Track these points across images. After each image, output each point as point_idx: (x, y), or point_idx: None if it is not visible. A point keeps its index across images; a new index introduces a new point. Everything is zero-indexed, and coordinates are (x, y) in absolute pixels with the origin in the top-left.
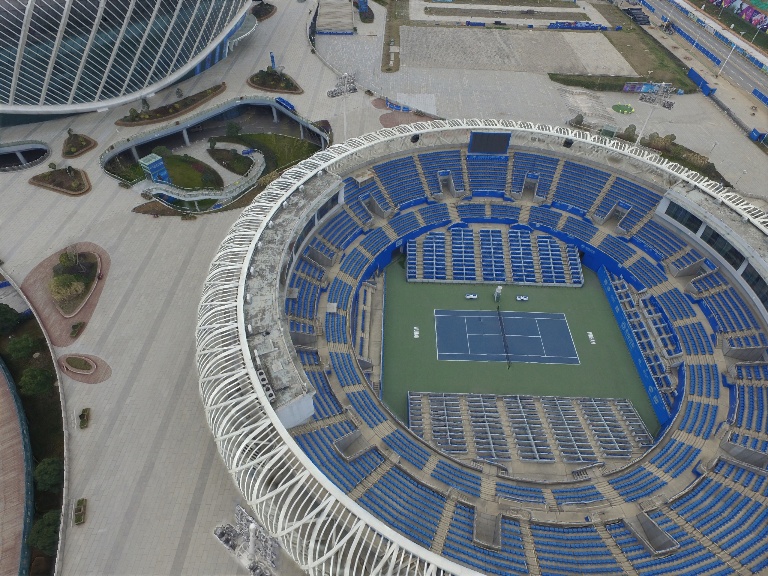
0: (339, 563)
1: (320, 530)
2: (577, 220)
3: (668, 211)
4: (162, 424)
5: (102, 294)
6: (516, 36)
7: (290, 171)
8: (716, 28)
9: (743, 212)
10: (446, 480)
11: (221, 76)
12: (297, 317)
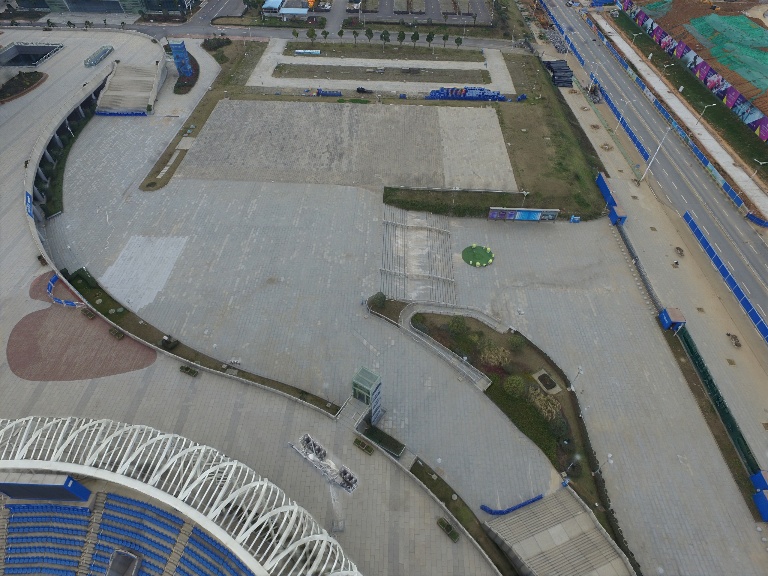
0: None
1: None
2: None
3: None
4: None
5: None
6: (371, 116)
7: None
8: (660, 90)
9: None
10: None
11: None
12: None
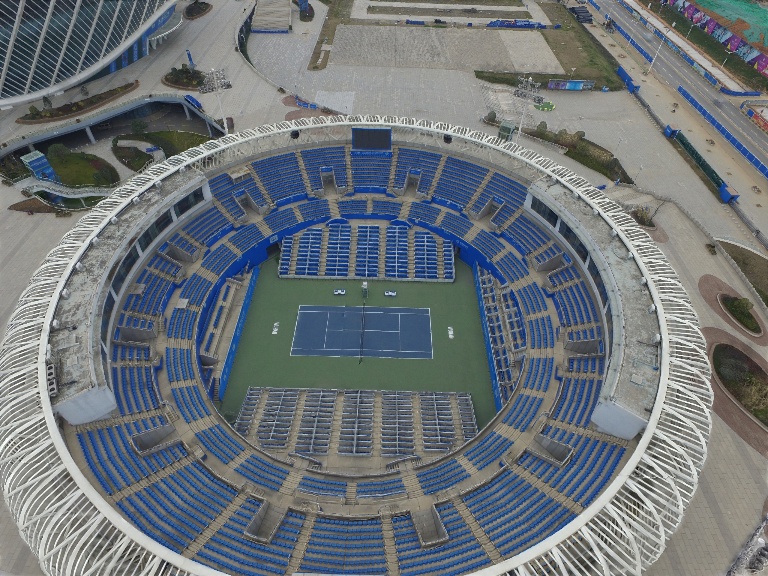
0: (65, 556)
1: (56, 523)
2: (454, 215)
3: (533, 206)
4: None
5: None
6: (452, 34)
7: (153, 167)
8: (658, 26)
9: (596, 206)
10: (248, 474)
11: (137, 74)
12: (138, 313)
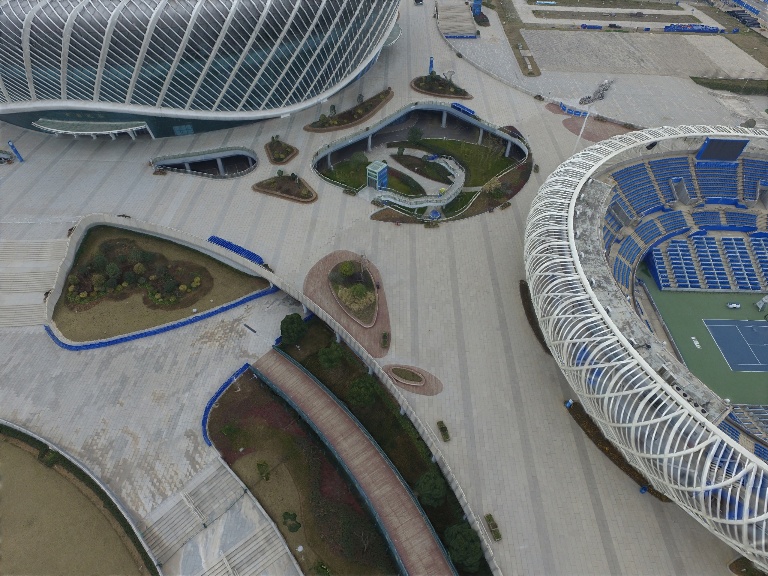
0: None
1: None
2: None
3: None
4: (522, 437)
5: (388, 304)
6: (640, 39)
7: (557, 179)
8: None
9: None
10: None
11: (382, 81)
12: None
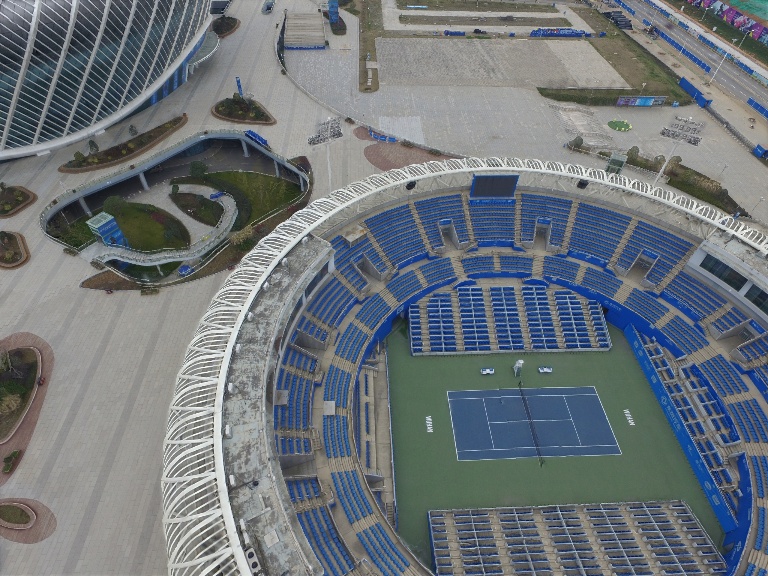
0: None
1: None
2: (598, 271)
3: (703, 264)
4: None
5: (43, 406)
6: (499, 46)
7: (269, 238)
8: (698, 31)
9: None
10: None
11: (181, 105)
12: (289, 430)
